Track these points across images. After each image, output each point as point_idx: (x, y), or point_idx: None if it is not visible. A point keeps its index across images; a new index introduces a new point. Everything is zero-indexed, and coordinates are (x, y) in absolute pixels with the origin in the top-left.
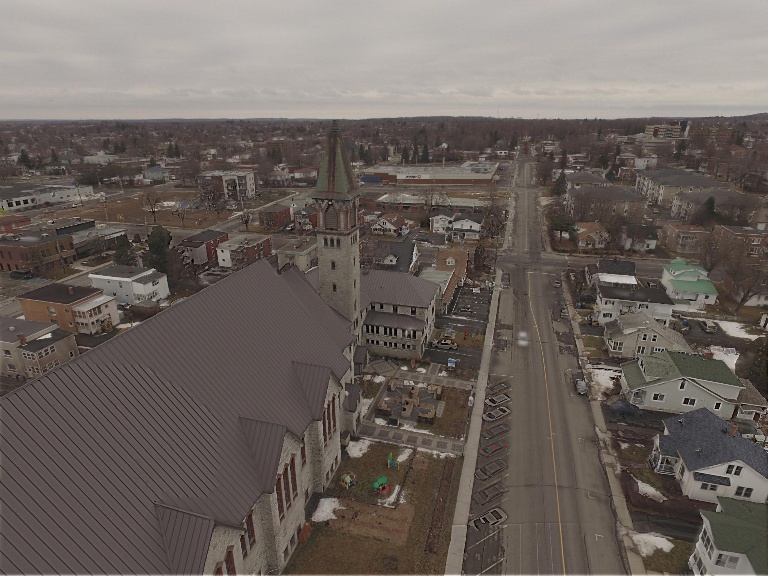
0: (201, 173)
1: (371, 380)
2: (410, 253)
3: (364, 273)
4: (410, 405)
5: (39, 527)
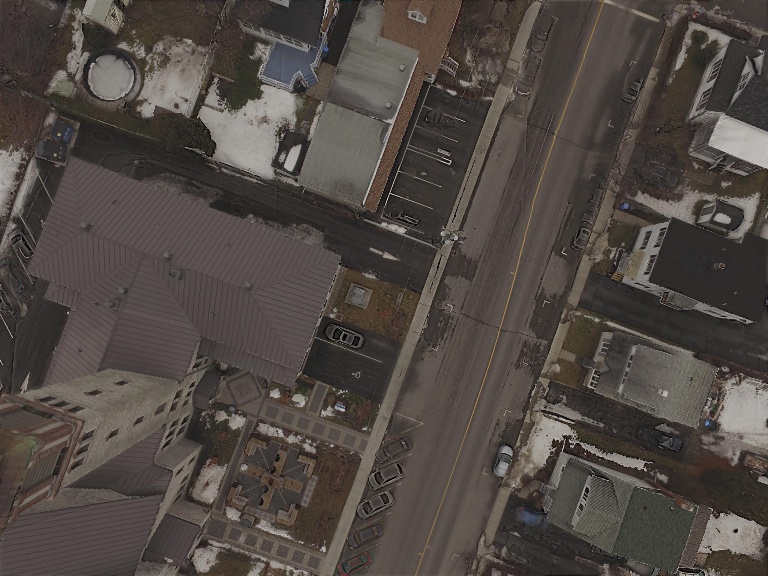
0: None
1: (223, 436)
2: None
3: (173, 278)
4: (269, 495)
5: None
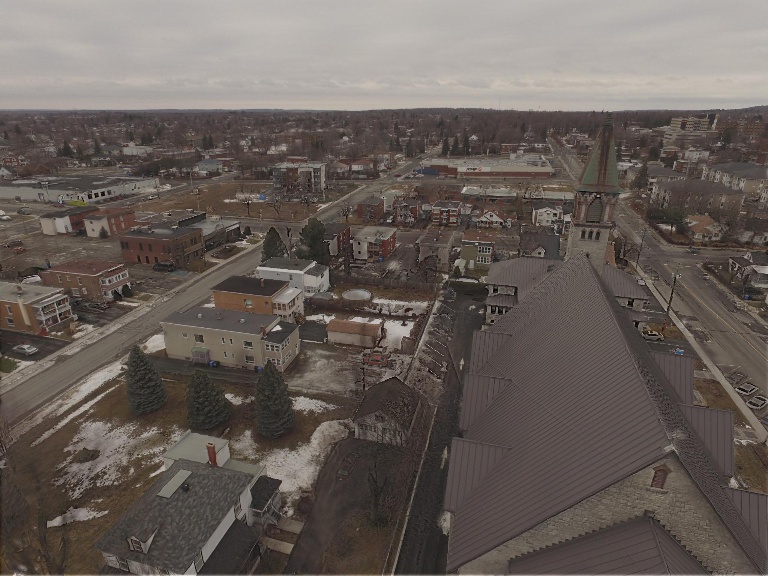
0: (275, 165)
1: None
2: (557, 245)
3: None
4: None
5: (722, 507)
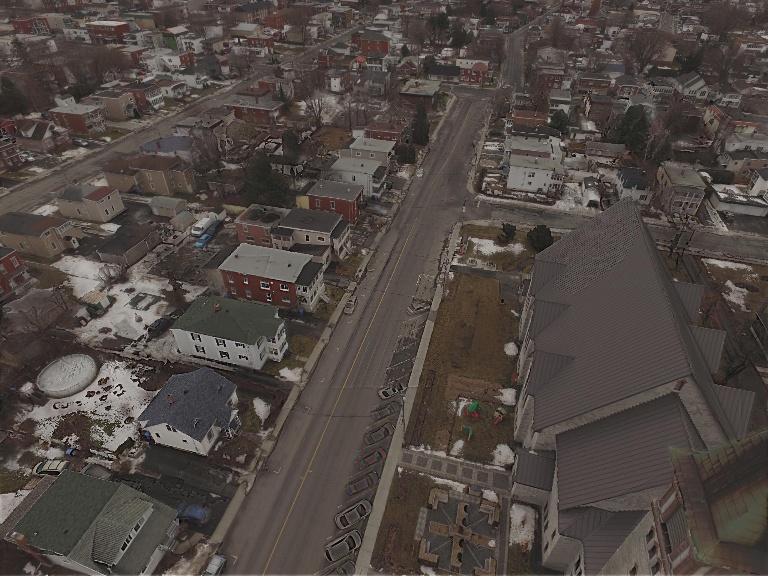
0: None
1: None
2: None
3: None
4: (460, 517)
5: None
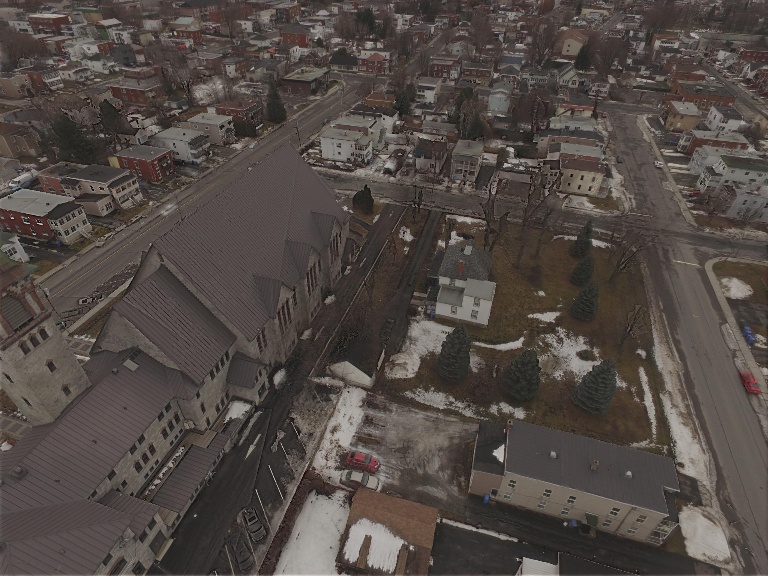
0: None
1: None
2: None
3: None
4: None
5: None
